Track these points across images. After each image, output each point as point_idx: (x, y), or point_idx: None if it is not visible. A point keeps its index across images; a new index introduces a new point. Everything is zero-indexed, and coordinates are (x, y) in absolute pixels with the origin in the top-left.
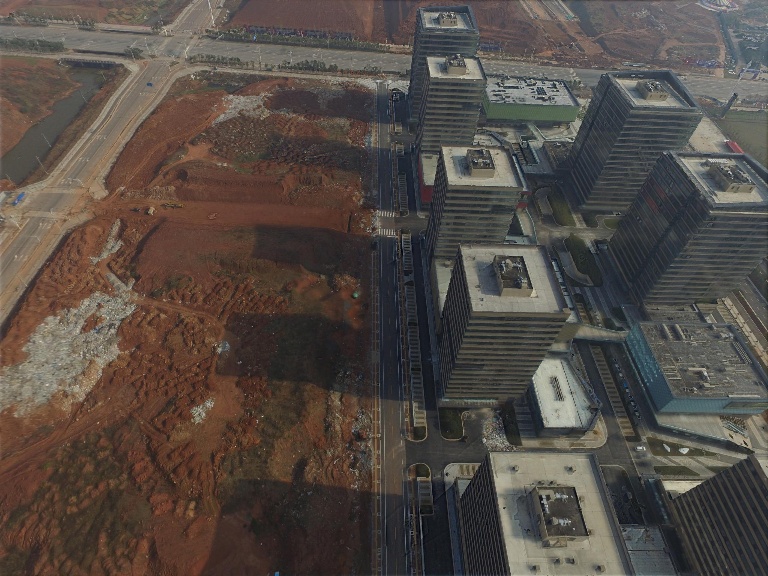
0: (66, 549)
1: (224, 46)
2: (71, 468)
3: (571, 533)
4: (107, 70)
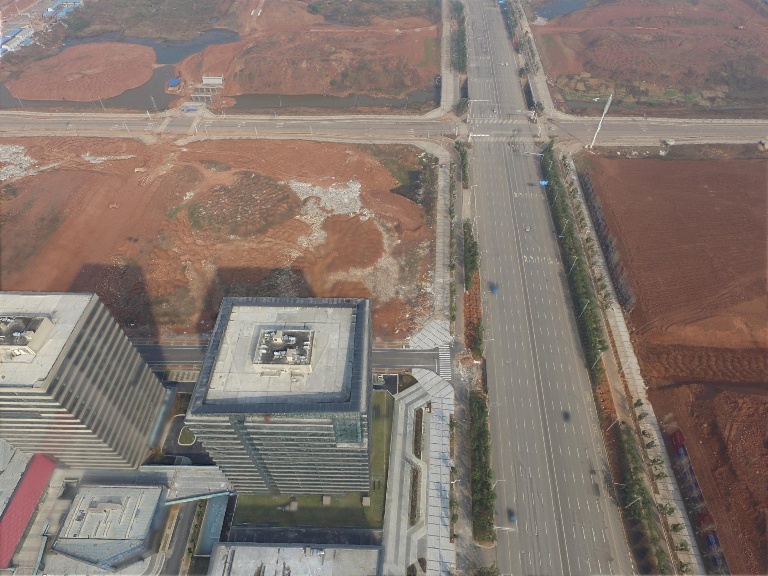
0: None
1: (520, 164)
2: None
3: None
4: (435, 104)
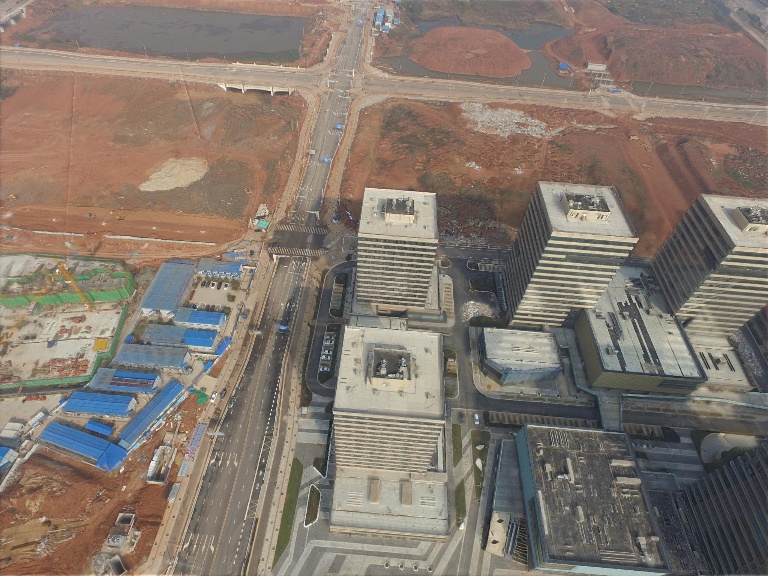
0: (402, 137)
1: None
2: (438, 133)
3: (388, 207)
4: None
